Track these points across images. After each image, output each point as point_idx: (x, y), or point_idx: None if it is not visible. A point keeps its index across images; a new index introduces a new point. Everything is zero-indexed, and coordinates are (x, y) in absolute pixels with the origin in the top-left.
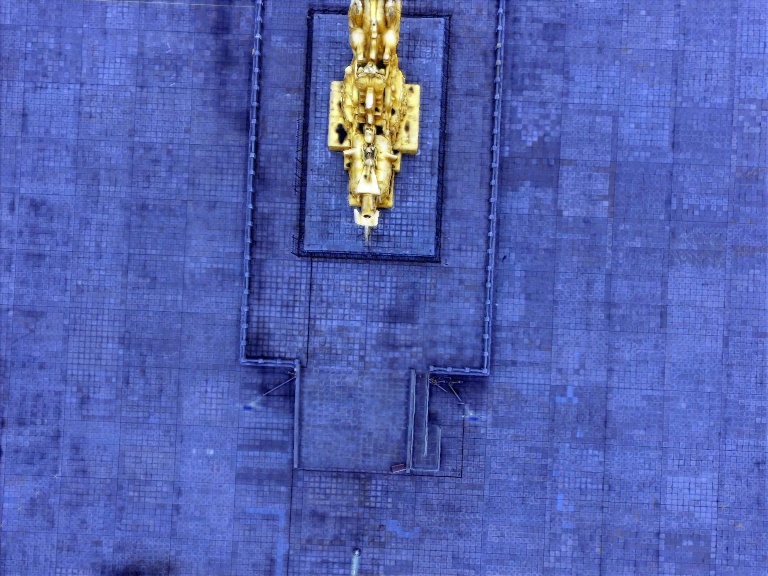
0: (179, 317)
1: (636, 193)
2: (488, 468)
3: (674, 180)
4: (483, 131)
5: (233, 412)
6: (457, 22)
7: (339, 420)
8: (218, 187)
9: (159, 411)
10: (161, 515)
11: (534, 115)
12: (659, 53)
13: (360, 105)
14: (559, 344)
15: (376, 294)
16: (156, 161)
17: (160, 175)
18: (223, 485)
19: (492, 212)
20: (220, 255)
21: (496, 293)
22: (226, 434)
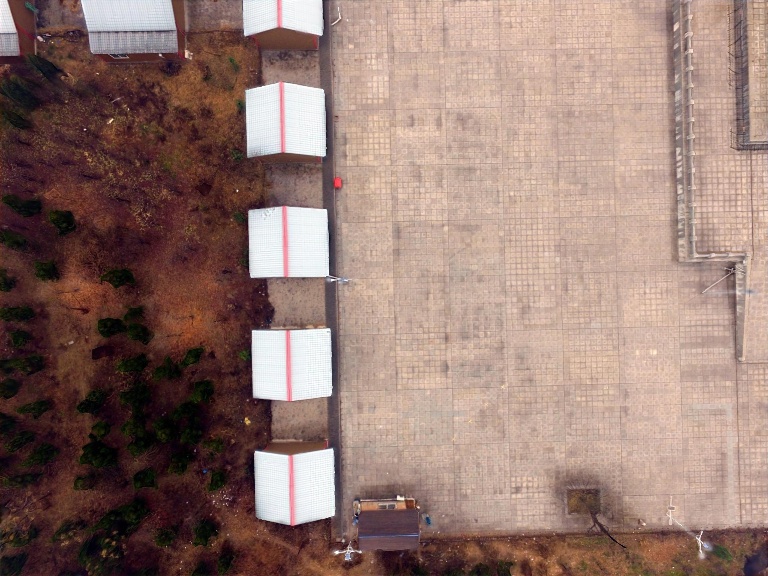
0: (613, 221)
1: None
2: None
3: None
4: None
5: (673, 311)
6: None
7: None
8: (643, 89)
9: (600, 315)
10: (610, 418)
11: None
12: None
13: None
14: None
15: None
16: (579, 67)
17: (584, 81)
18: (669, 384)
19: None
20: (649, 157)
21: None
22: (668, 333)
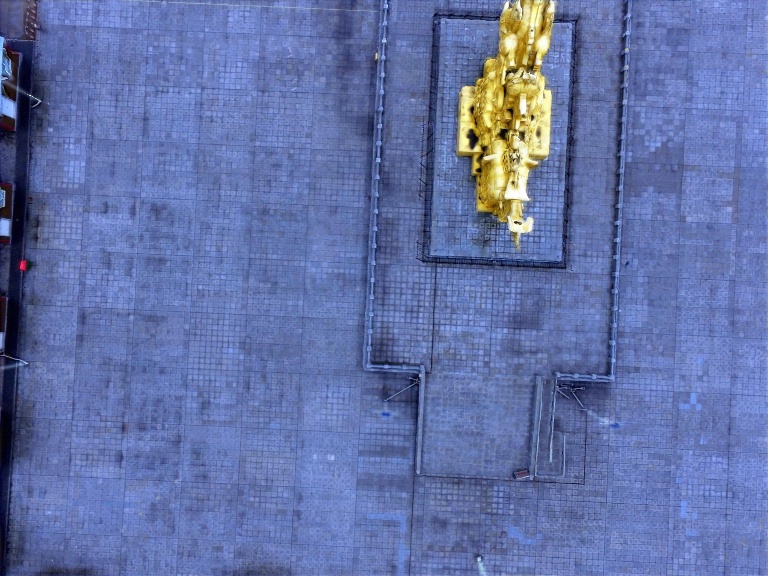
0: (300, 322)
1: (760, 199)
2: (611, 475)
3: None
4: (609, 136)
5: (354, 418)
6: (583, 27)
7: (462, 426)
8: (339, 192)
9: (280, 416)
10: (282, 521)
11: (657, 120)
12: None
13: (506, 111)
14: (682, 350)
15: (501, 300)
16: (277, 166)
17: (281, 180)
18: (344, 491)
19: (619, 218)
20: (341, 260)
21: (619, 299)
22: (347, 440)
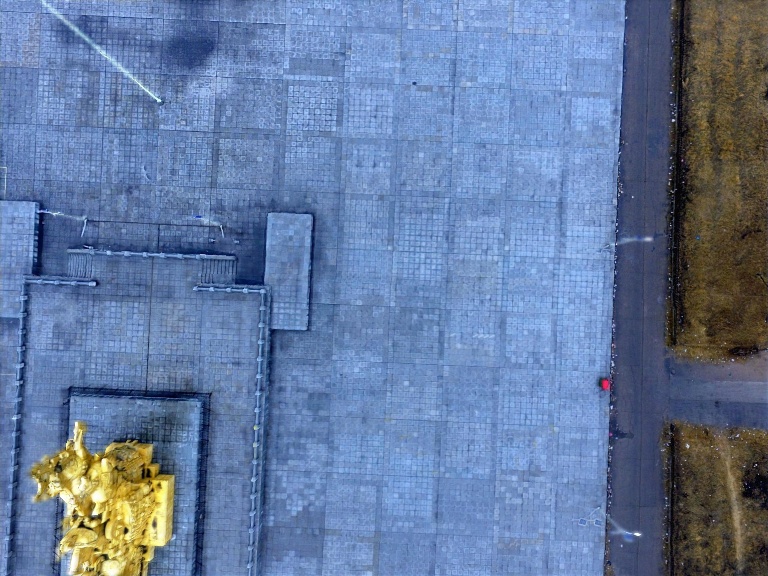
0: None
1: (400, 563)
2: None
3: (438, 551)
4: (243, 509)
5: None
6: (217, 399)
7: None
8: None
9: None
10: None
11: (299, 484)
12: (423, 423)
13: None
14: None
15: None
16: None
17: None
18: None
19: None
20: None
21: None
22: None
